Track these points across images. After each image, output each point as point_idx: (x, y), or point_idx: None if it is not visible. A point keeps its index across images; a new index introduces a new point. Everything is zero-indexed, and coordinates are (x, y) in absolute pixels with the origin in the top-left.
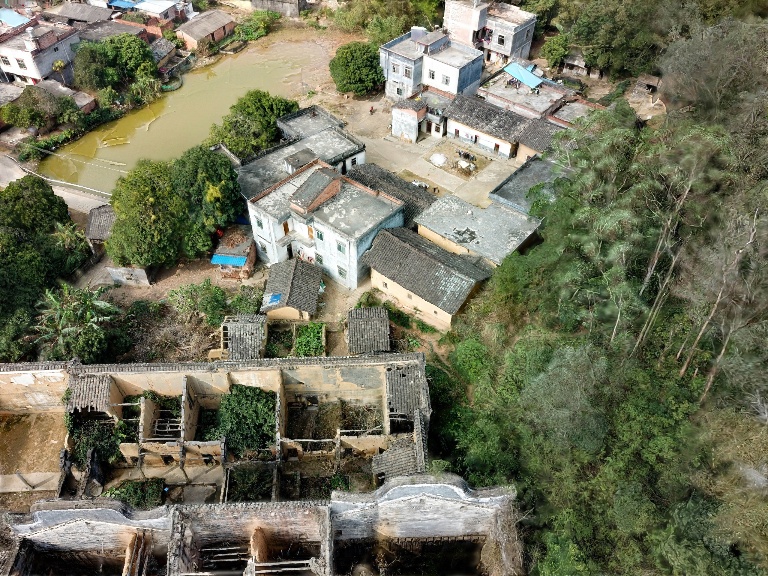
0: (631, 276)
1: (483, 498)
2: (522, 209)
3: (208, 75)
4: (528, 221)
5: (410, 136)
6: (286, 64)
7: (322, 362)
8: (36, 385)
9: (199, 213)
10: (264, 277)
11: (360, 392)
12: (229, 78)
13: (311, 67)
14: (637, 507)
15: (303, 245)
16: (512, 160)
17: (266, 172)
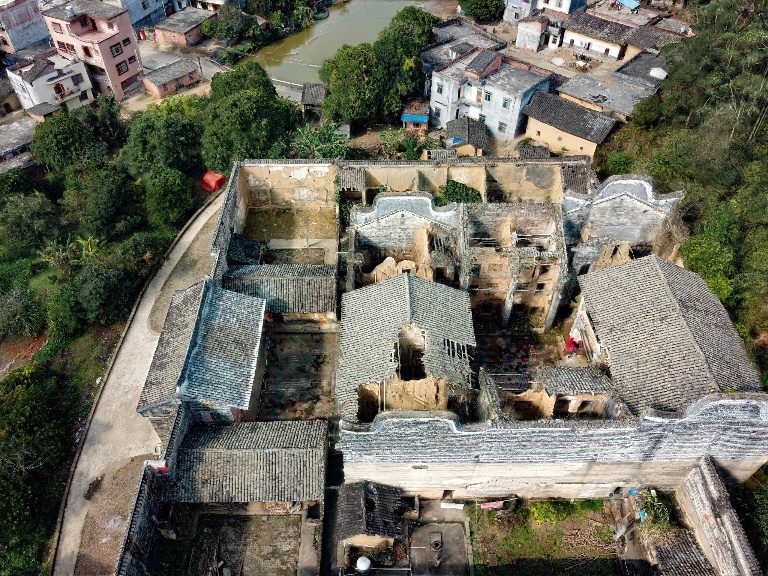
0: (753, 77)
1: (661, 200)
2: (641, 82)
3: (342, 12)
4: (646, 90)
5: (532, 46)
6: (410, 1)
7: (516, 160)
8: (306, 180)
9: (394, 81)
10: (437, 135)
11: (535, 192)
12: (365, 11)
13: (432, 3)
14: (763, 207)
15: (469, 109)
16: (619, 61)
17: (433, 60)
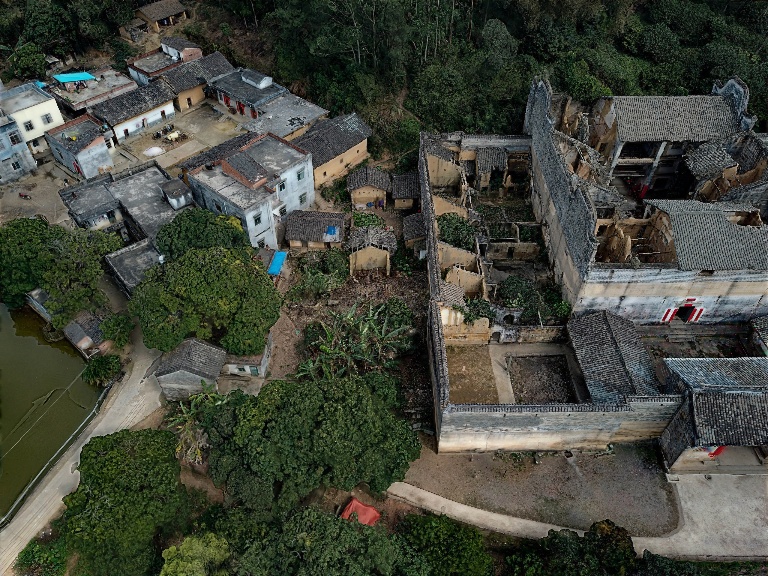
0: None
1: None
2: (276, 94)
3: None
4: (285, 97)
5: (107, 164)
6: None
7: None
8: None
9: None
10: None
11: None
12: None
13: None
14: None
15: None
16: (177, 114)
17: None
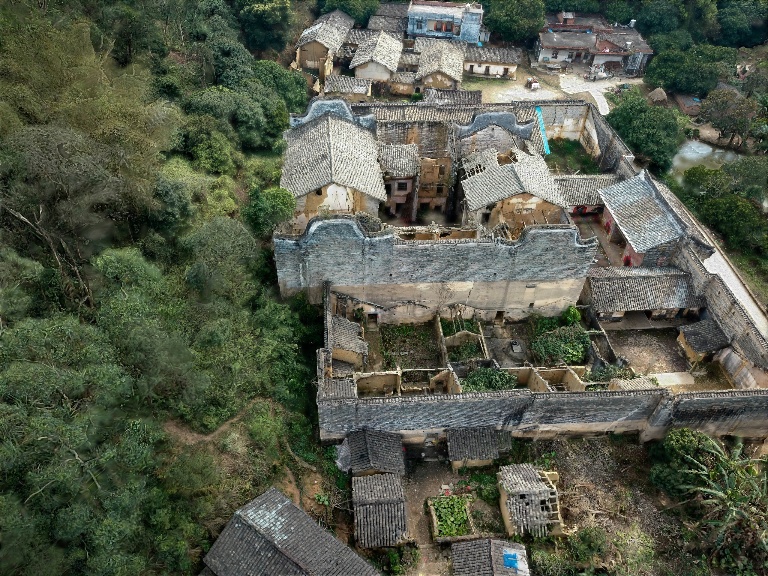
0: None
1: None
2: None
3: None
4: None
5: None
6: None
7: None
8: None
9: None
10: None
11: None
12: None
13: None
14: None
15: None
16: None
17: None
